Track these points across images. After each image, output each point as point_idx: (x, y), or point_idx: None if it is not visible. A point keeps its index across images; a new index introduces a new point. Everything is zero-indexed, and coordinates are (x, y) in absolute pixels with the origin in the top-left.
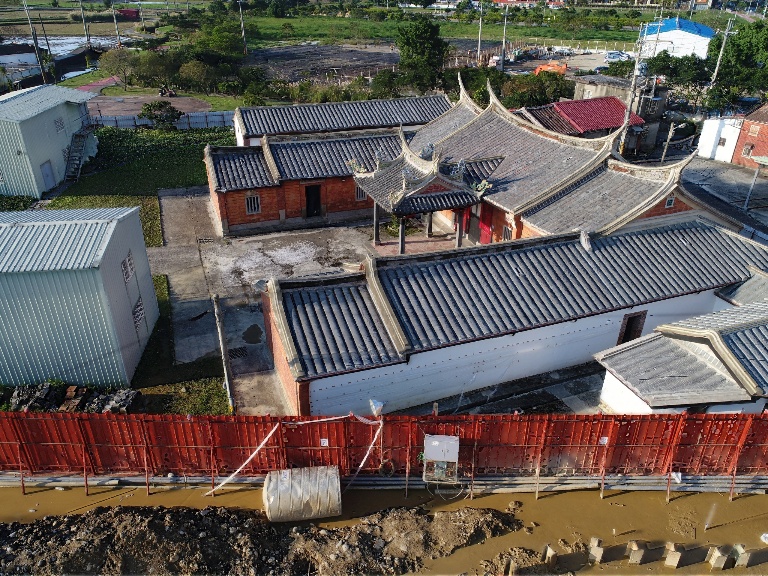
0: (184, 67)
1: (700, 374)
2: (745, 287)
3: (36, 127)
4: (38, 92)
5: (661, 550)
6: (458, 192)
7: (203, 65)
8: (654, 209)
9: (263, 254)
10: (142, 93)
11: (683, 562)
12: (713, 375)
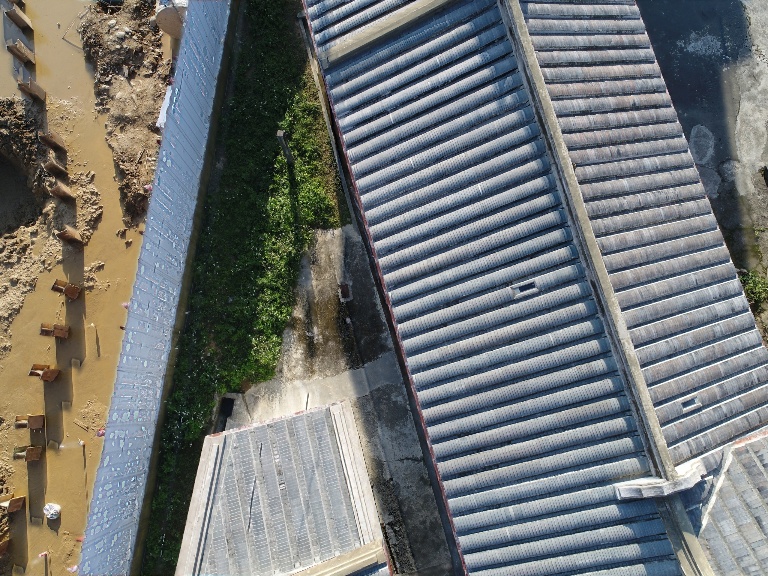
0: None
1: (242, 551)
2: None
3: None
4: None
5: (68, 373)
6: None
7: None
8: None
9: None
10: None
11: (49, 390)
12: (237, 575)
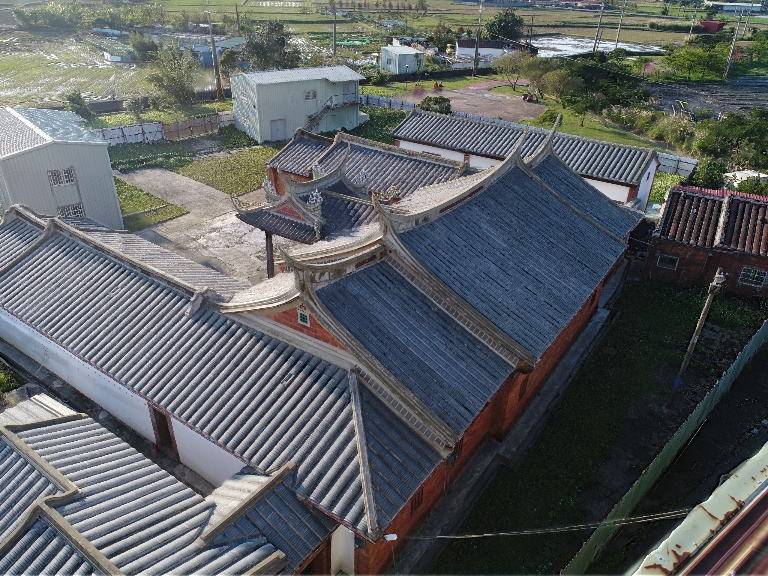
0: (548, 75)
1: None
2: (248, 479)
3: (278, 92)
4: (321, 69)
5: None
6: (311, 226)
7: (563, 75)
8: (284, 315)
9: (253, 228)
10: (519, 94)
11: None
12: None
